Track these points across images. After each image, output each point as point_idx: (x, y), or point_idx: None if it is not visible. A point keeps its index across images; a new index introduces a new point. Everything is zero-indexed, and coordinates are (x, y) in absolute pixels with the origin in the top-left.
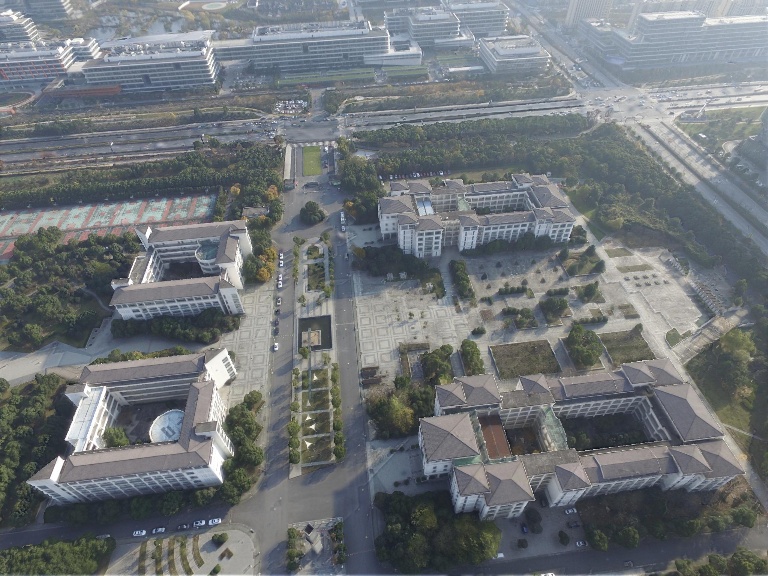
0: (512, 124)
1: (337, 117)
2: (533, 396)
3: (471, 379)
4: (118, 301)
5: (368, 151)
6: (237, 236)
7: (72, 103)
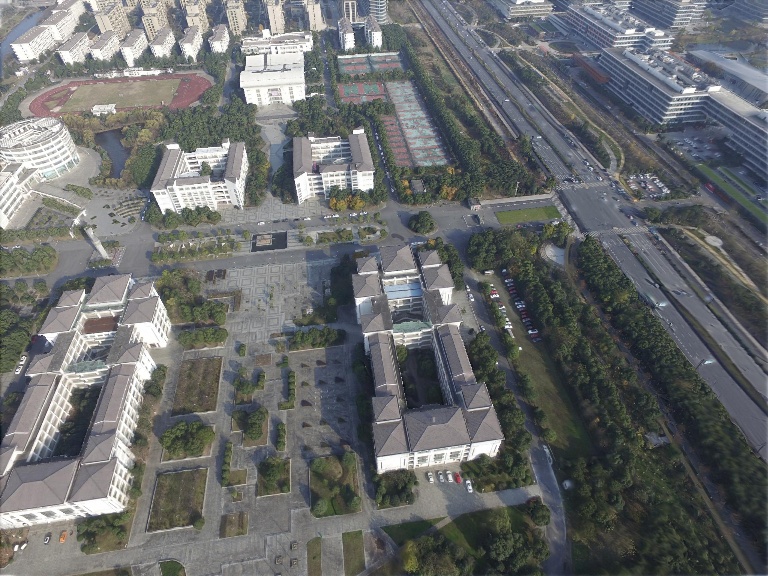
0: (708, 431)
1: (643, 225)
2: (119, 349)
3: (151, 305)
4: (295, 139)
5: (565, 258)
6: None
7: (568, 69)
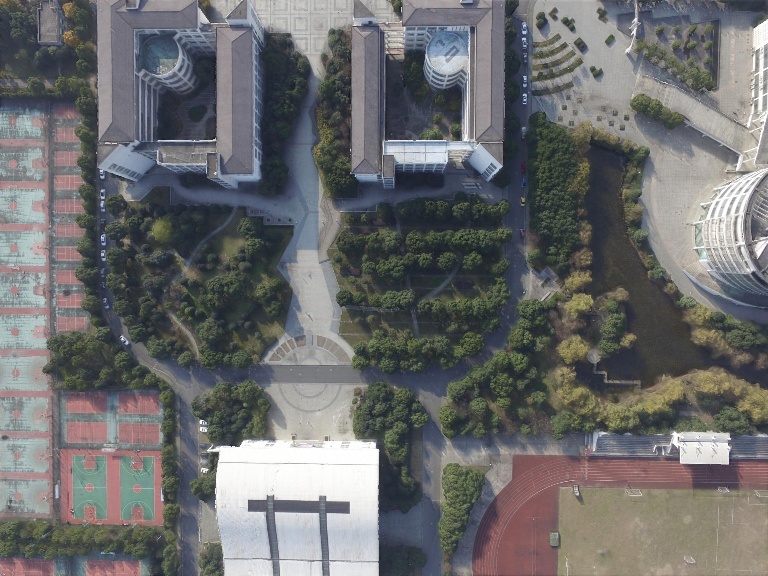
0: None
1: None
2: None
3: None
4: (248, 162)
5: None
6: (139, 0)
7: None
